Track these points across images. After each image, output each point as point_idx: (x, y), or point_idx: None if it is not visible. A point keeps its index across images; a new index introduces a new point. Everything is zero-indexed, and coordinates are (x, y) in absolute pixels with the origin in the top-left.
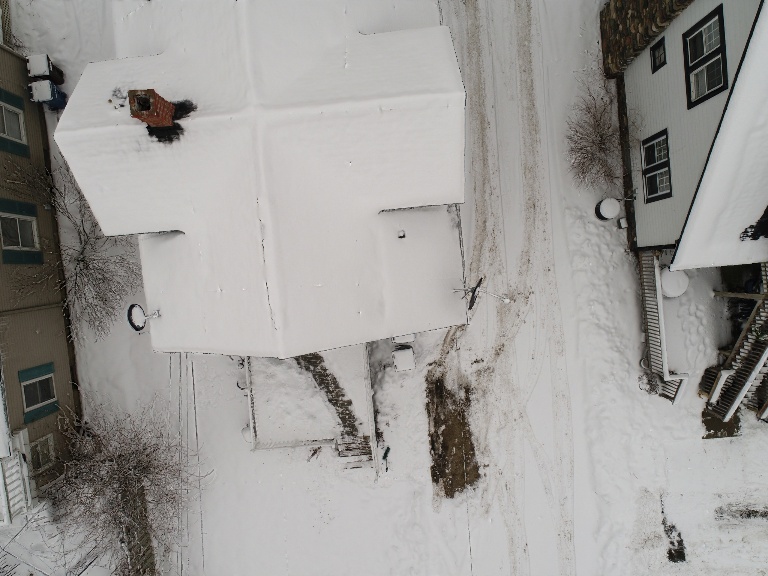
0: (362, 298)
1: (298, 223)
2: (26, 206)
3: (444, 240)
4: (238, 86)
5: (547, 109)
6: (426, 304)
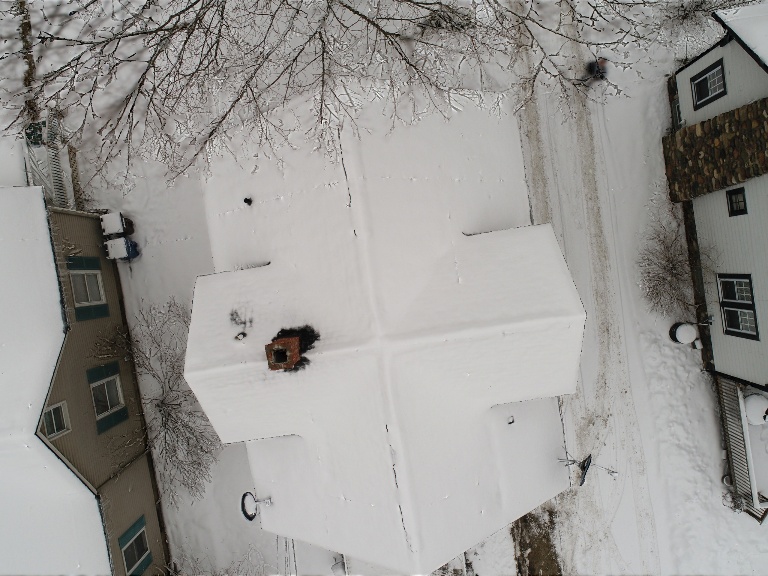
0: (482, 496)
1: (424, 441)
2: (110, 366)
3: (547, 413)
4: (360, 315)
5: (615, 236)
6: (536, 482)
